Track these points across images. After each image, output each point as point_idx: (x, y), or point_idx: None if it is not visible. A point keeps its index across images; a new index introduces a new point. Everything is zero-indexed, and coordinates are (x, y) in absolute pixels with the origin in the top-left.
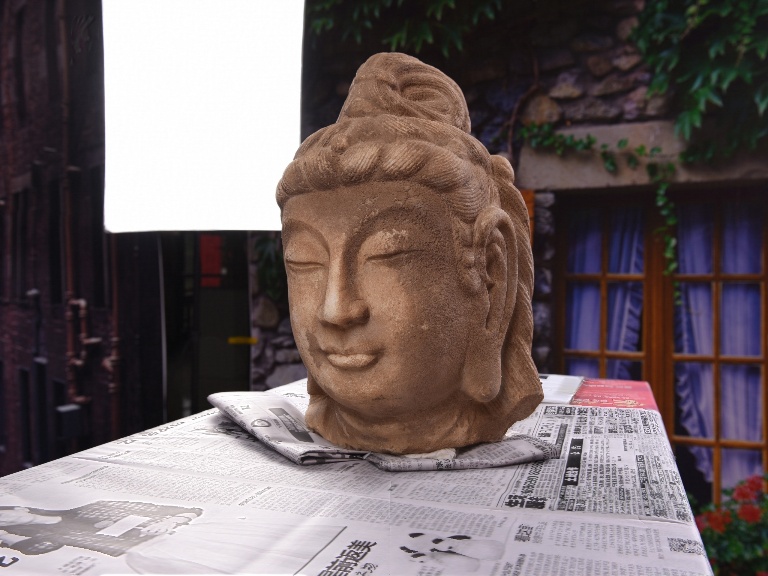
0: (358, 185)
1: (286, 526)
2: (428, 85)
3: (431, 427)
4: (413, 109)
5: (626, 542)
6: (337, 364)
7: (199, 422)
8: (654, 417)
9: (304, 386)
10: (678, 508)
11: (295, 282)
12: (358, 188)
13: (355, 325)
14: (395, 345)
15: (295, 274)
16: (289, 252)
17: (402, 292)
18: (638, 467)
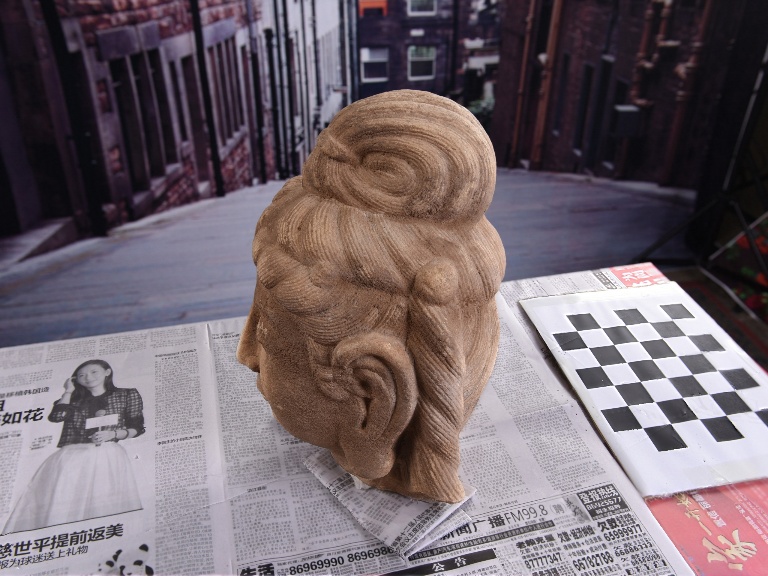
0: None
1: (133, 482)
2: (395, 153)
3: None
4: (346, 192)
5: None
6: None
7: None
8: None
9: (511, 294)
10: None
11: None
12: None
13: None
14: None
15: None
16: None
17: (266, 373)
18: None
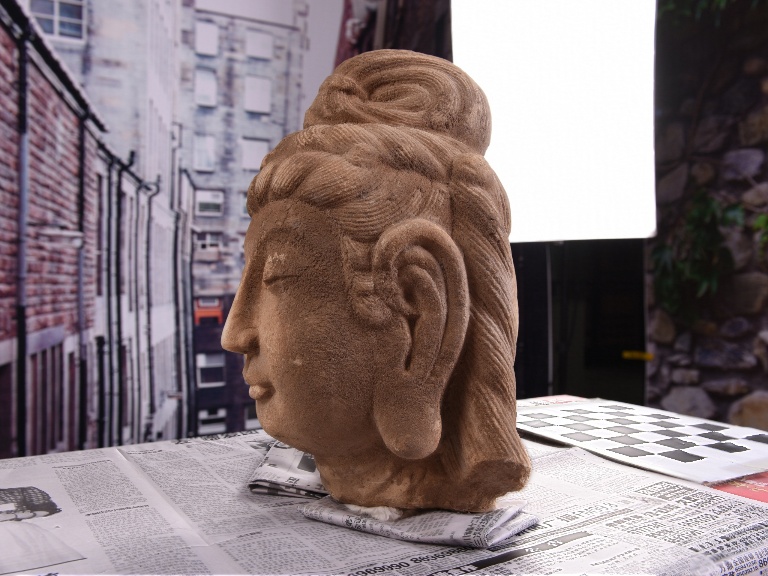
0: (264, 206)
1: (59, 543)
2: (405, 80)
3: (360, 478)
4: (362, 113)
5: None
6: None
7: None
8: None
9: None
10: None
11: None
12: (264, 209)
13: (254, 354)
14: (275, 379)
15: None
16: None
17: (277, 322)
18: None
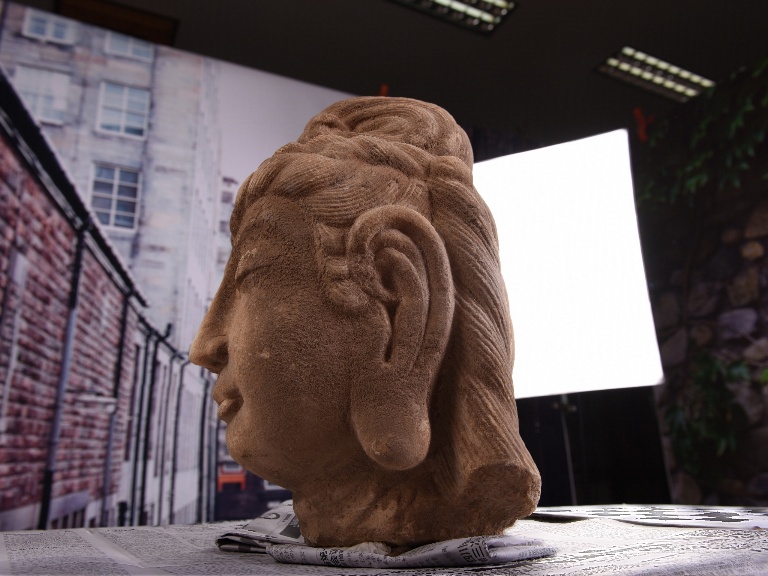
0: None
1: None
2: (385, 114)
3: (339, 506)
4: None
5: None
6: None
7: None
8: None
9: None
10: None
11: None
12: None
13: None
14: (241, 382)
15: None
16: None
17: (246, 317)
18: (555, 574)
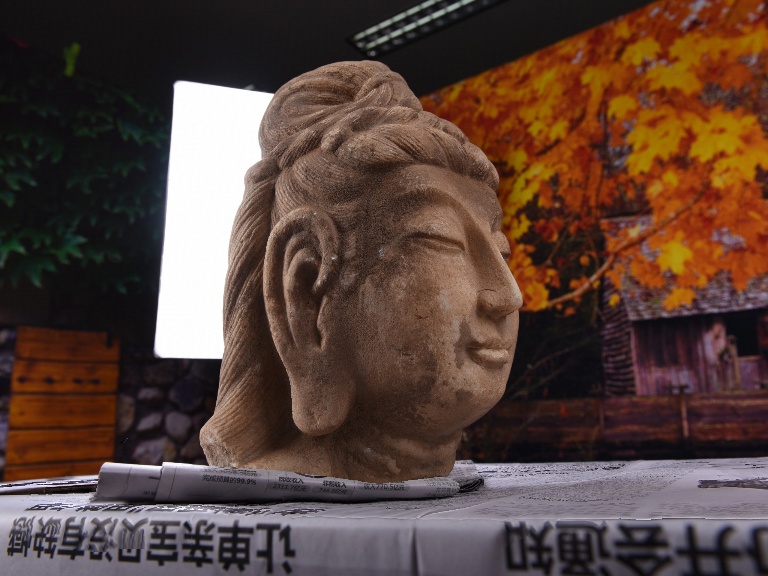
0: (479, 181)
1: None
2: None
3: None
4: None
5: None
6: (494, 359)
7: None
8: None
9: None
10: None
11: (437, 262)
12: None
13: None
14: None
15: (436, 252)
16: (436, 224)
17: None
18: None
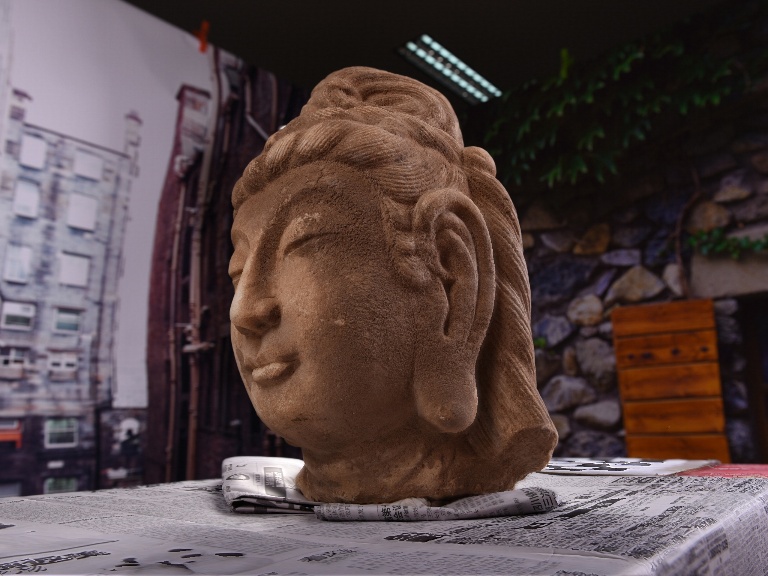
0: (279, 177)
1: (55, 538)
2: (397, 91)
3: (386, 466)
4: None
5: (470, 570)
6: (254, 379)
7: (199, 483)
8: (765, 482)
9: None
10: (643, 545)
11: None
12: (279, 180)
13: (269, 329)
14: (306, 347)
15: None
16: None
17: (312, 282)
18: (658, 515)
